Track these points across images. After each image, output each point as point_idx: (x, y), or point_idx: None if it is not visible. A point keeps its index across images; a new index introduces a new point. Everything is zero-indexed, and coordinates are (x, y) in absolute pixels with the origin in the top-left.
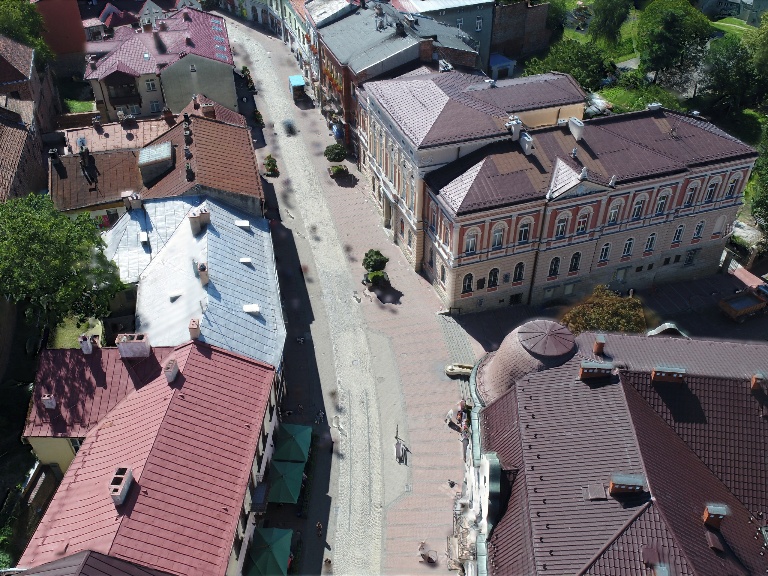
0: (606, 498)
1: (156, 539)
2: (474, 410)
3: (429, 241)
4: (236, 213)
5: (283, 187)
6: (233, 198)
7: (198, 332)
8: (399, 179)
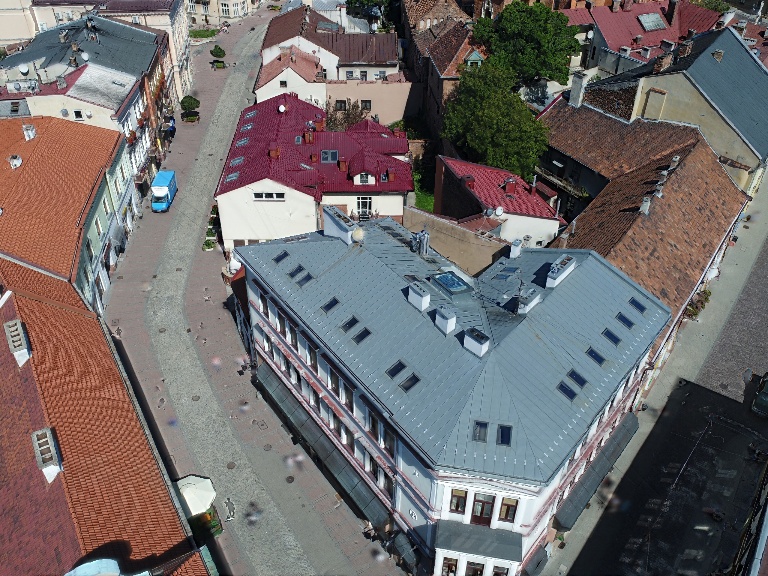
0: None
1: None
2: None
3: None
4: None
5: None
6: None
7: None
8: None
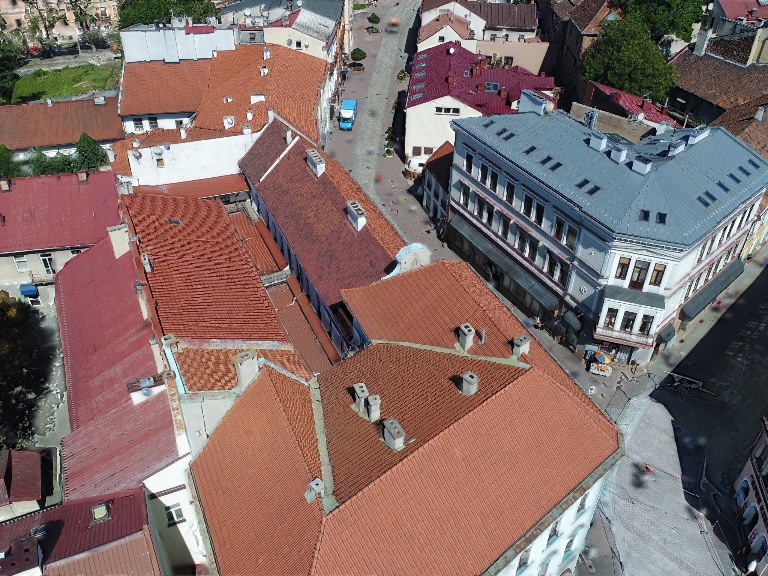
0: None
1: None
2: None
3: None
4: None
5: (399, 69)
6: None
7: None
8: None
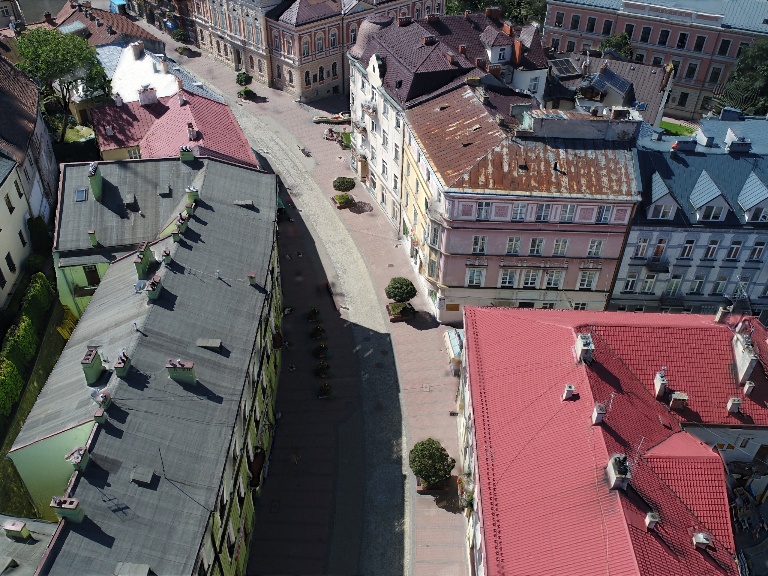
0: (424, 46)
1: (221, 148)
2: (355, 62)
3: (275, 61)
4: (151, 52)
5: None
6: (146, 43)
7: (182, 85)
8: (244, 27)
